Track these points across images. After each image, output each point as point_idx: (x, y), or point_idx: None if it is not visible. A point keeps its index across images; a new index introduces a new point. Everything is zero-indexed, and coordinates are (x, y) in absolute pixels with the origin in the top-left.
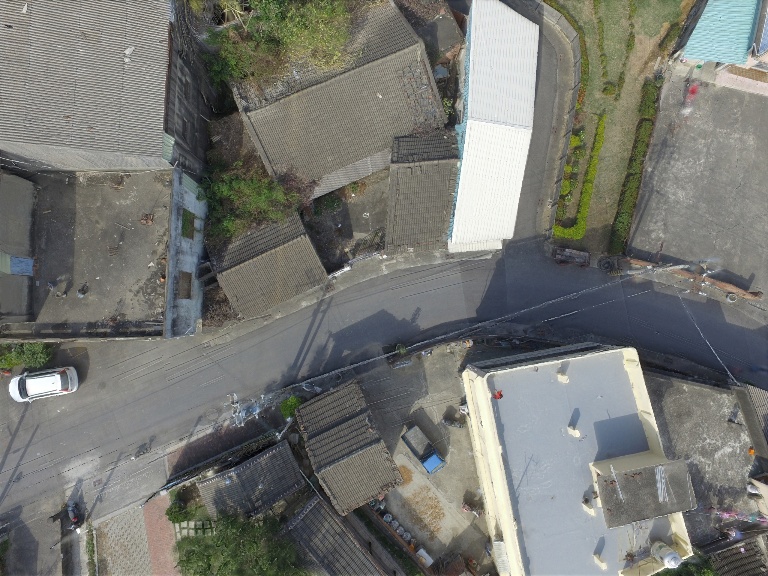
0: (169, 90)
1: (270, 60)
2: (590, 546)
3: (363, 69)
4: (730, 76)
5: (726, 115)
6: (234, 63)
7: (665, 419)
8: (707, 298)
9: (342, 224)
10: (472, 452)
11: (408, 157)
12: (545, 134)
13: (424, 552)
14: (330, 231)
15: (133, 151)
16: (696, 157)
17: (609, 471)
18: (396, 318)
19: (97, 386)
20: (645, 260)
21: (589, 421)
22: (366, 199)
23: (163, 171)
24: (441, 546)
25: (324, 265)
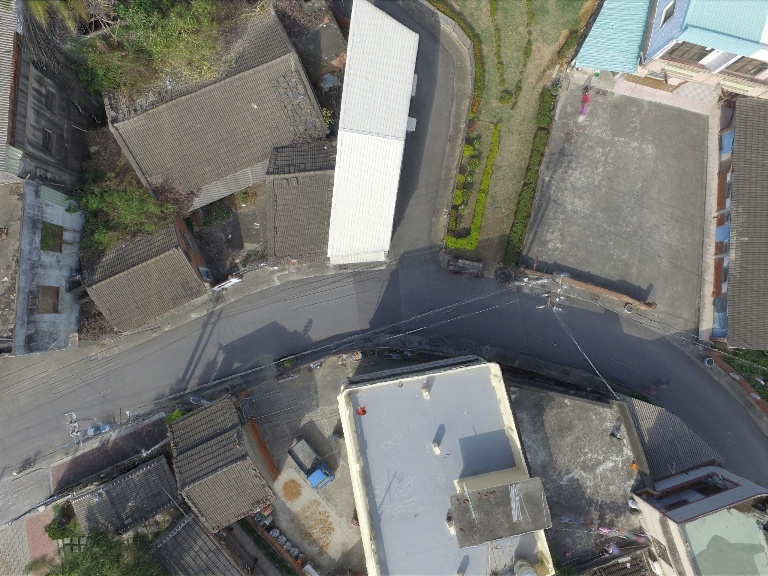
0: (16, 102)
1: (141, 70)
2: (454, 565)
3: (234, 79)
4: (629, 84)
5: (625, 124)
6: (102, 73)
7: (546, 433)
8: (605, 309)
9: (232, 235)
10: None
11: (284, 168)
12: (441, 143)
13: (310, 568)
14: (220, 242)
15: None
16: (594, 166)
17: (464, 489)
18: (288, 330)
19: None
20: (542, 270)
21: (454, 437)
22: (257, 209)
23: (19, 184)
24: (330, 561)
25: (214, 276)
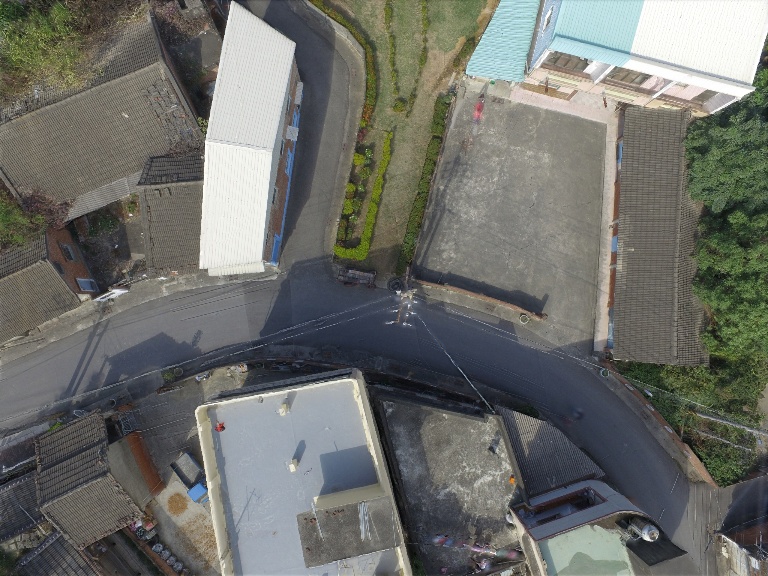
0: None
1: (8, 78)
2: None
3: (101, 88)
4: (525, 92)
5: (521, 132)
6: None
7: (423, 447)
8: (500, 319)
9: (119, 245)
10: None
11: (156, 178)
12: (335, 151)
13: None
14: (106, 252)
15: None
16: (489, 175)
17: None
18: (176, 341)
19: None
20: (436, 281)
21: (315, 454)
22: None
23: None
24: (216, 575)
25: (99, 287)
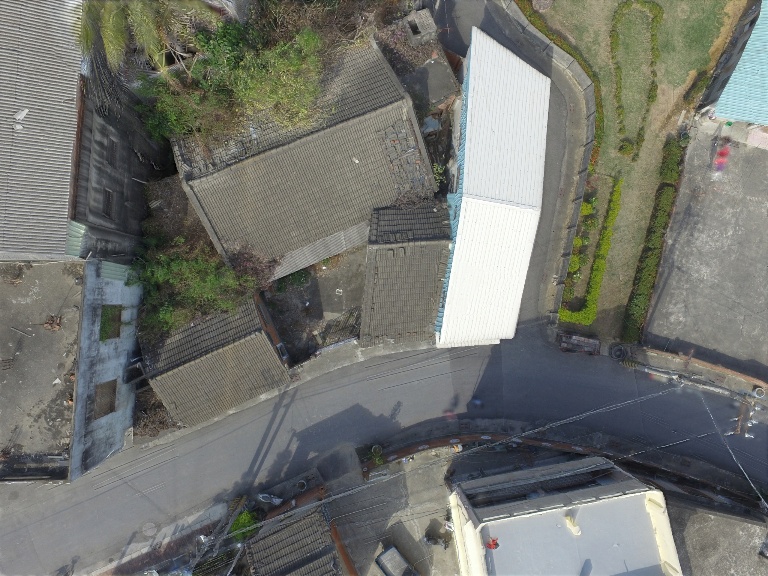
0: (78, 163)
1: (220, 114)
2: None
3: (335, 129)
4: (764, 136)
5: (758, 181)
6: (173, 118)
7: (687, 552)
8: (731, 392)
9: (310, 302)
10: (459, 574)
11: (389, 236)
12: (551, 198)
13: None
14: (296, 310)
15: (24, 248)
16: (723, 229)
17: None
18: (373, 414)
19: (8, 496)
20: (662, 347)
21: (603, 575)
22: (340, 272)
23: (75, 261)
24: None
25: (288, 351)
